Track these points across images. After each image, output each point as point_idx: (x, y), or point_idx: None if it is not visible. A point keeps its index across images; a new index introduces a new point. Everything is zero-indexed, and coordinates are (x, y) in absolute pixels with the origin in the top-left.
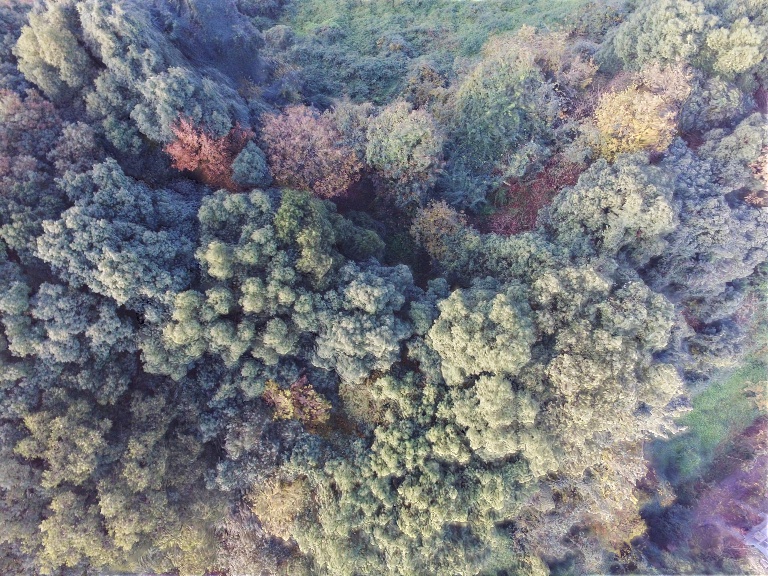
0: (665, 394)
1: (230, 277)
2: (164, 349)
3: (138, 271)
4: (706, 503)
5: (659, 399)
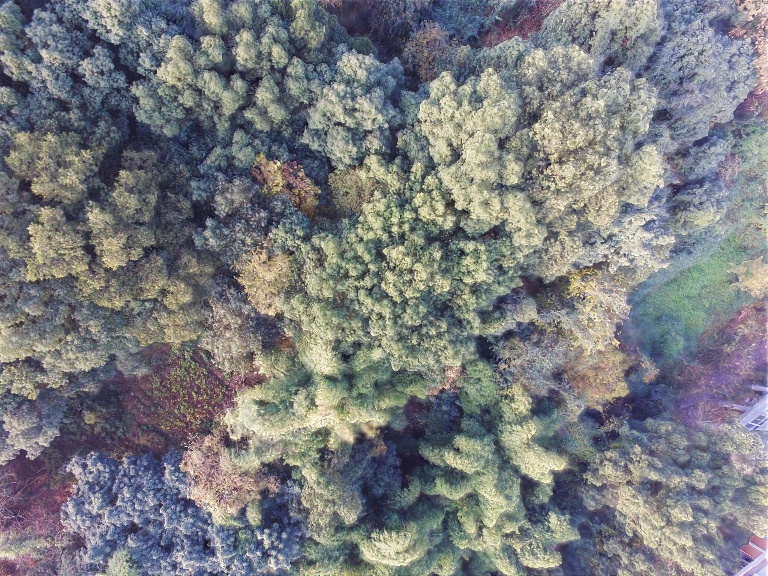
0: (646, 189)
1: (225, 31)
2: (157, 93)
3: (135, 2)
4: (688, 380)
5: (641, 195)
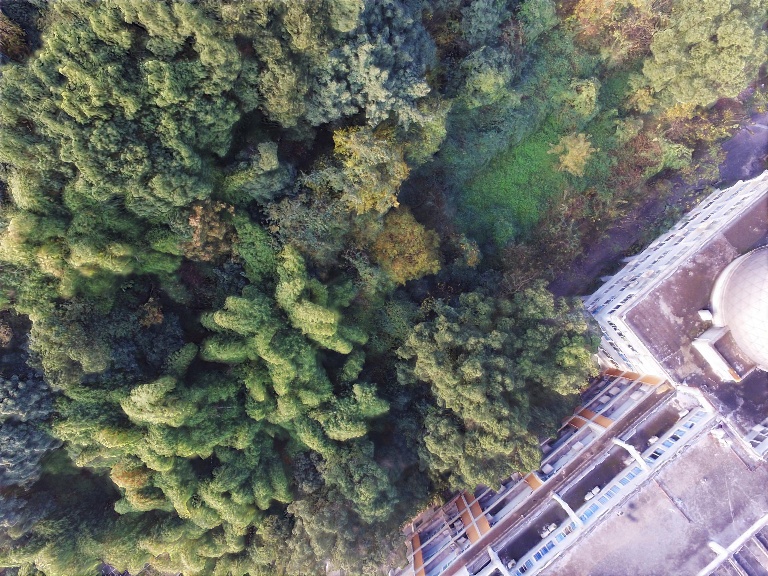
0: (352, 13)
1: None
2: None
3: None
4: (512, 261)
5: (347, 19)
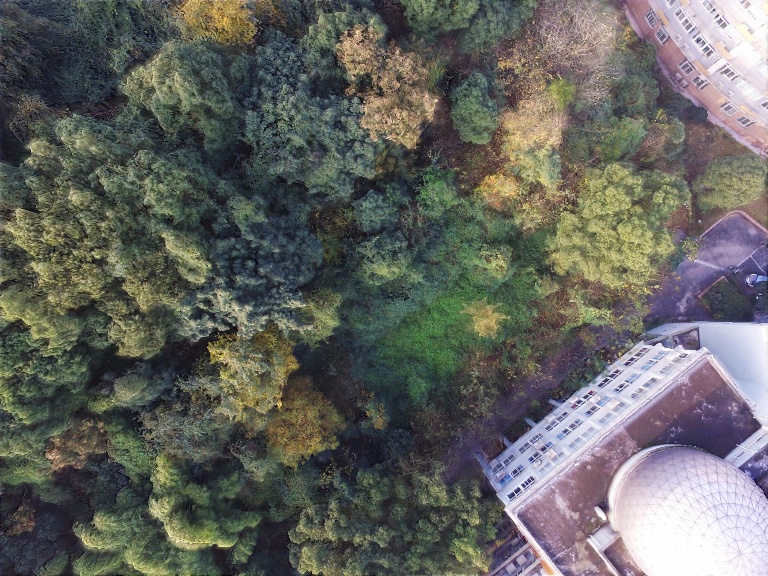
0: (199, 269)
1: None
2: None
3: None
4: (420, 425)
5: (195, 274)
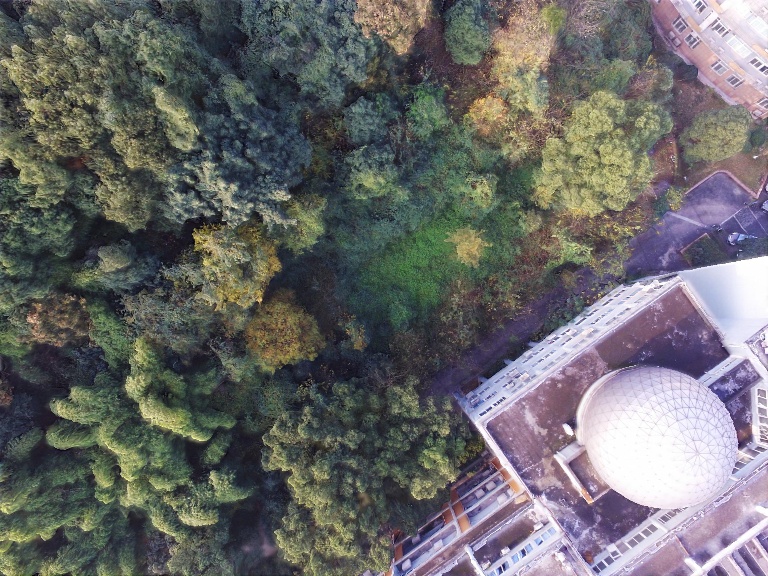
0: (187, 134)
1: None
2: None
3: None
4: (398, 348)
5: (183, 140)
